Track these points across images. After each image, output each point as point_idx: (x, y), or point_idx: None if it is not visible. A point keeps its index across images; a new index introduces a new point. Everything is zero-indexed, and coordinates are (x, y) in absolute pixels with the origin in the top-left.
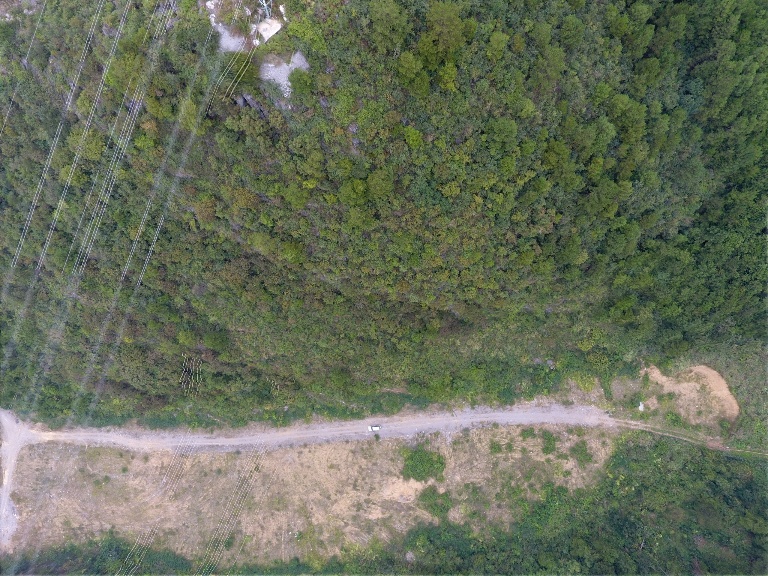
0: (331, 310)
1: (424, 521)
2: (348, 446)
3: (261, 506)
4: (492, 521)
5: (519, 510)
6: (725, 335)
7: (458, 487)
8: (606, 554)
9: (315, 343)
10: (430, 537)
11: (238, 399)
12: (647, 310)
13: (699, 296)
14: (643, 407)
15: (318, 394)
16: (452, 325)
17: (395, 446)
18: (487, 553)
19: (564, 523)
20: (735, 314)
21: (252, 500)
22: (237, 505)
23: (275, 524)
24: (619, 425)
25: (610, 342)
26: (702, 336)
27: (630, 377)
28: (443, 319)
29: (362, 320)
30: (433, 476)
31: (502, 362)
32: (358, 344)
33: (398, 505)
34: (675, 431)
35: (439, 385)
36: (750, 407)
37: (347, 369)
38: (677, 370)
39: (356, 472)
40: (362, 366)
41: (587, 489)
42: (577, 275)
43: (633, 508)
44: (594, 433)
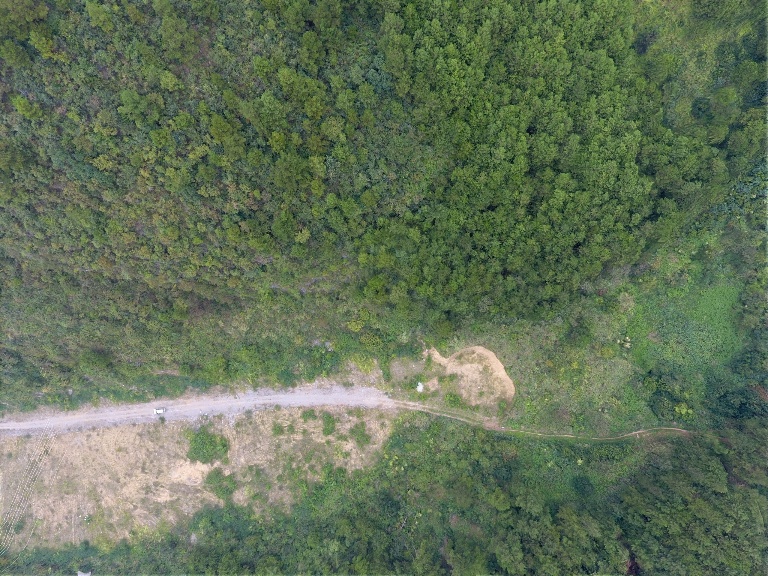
0: (61, 289)
1: (211, 503)
2: (135, 429)
3: (51, 489)
4: (273, 503)
5: (299, 491)
6: (485, 314)
7: (242, 469)
8: (363, 533)
9: (57, 323)
10: (213, 519)
11: (10, 382)
12: (398, 289)
13: (441, 274)
14: (422, 388)
15: (96, 377)
16: (202, 305)
17: (180, 429)
18: (263, 534)
19: (336, 503)
20: (489, 293)
21: (41, 484)
22: (27, 489)
23: (65, 507)
24: (398, 406)
25: (381, 323)
26: (466, 316)
27: (411, 358)
28: (188, 299)
29: (96, 299)
30: (218, 458)
31: (275, 344)
32: (101, 324)
33: (186, 488)
34: (452, 412)
35: (214, 367)
36: (522, 387)
37: (109, 350)
38: (453, 351)
39: (144, 455)
40: (123, 347)
41: (365, 470)
42: (308, 253)
43: (399, 488)
44: (373, 414)
